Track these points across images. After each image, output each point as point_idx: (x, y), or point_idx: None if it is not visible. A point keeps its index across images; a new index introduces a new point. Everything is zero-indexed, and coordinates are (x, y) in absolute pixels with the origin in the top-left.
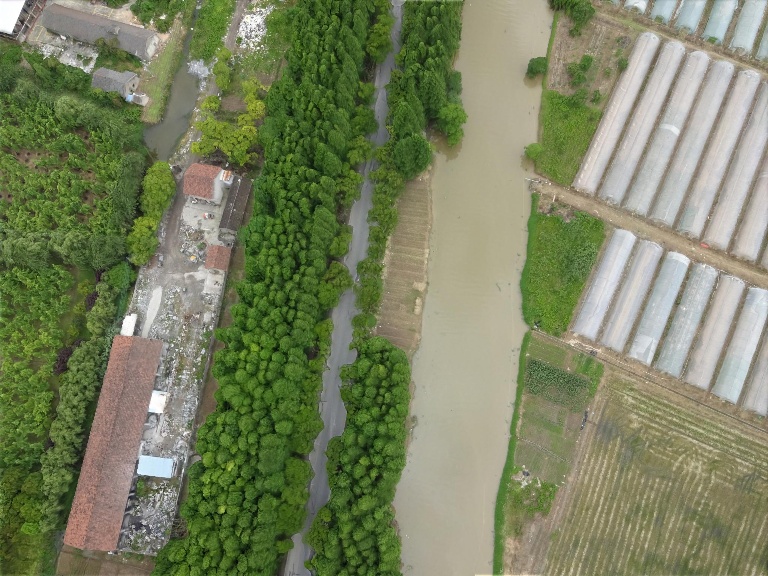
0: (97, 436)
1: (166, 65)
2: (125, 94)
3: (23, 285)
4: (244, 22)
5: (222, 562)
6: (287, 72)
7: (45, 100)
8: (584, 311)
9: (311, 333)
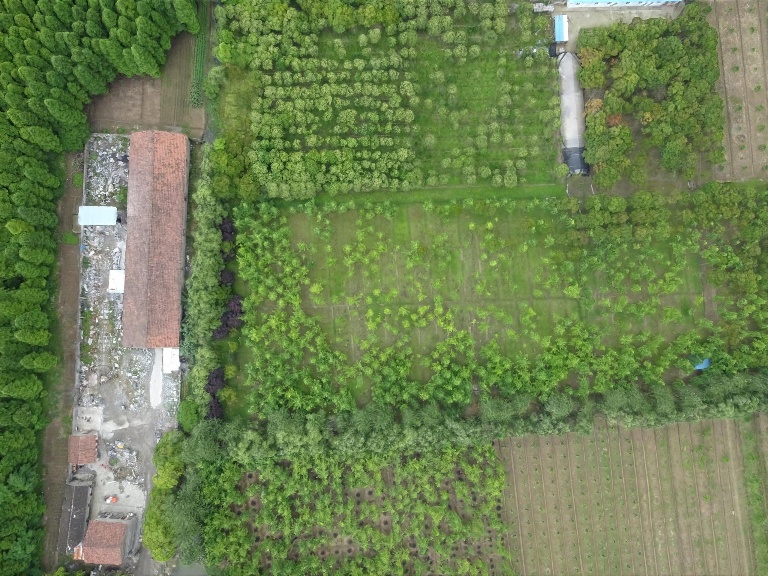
0: (171, 239)
1: None
2: None
3: (306, 391)
4: None
5: None
6: None
7: None
8: None
9: None
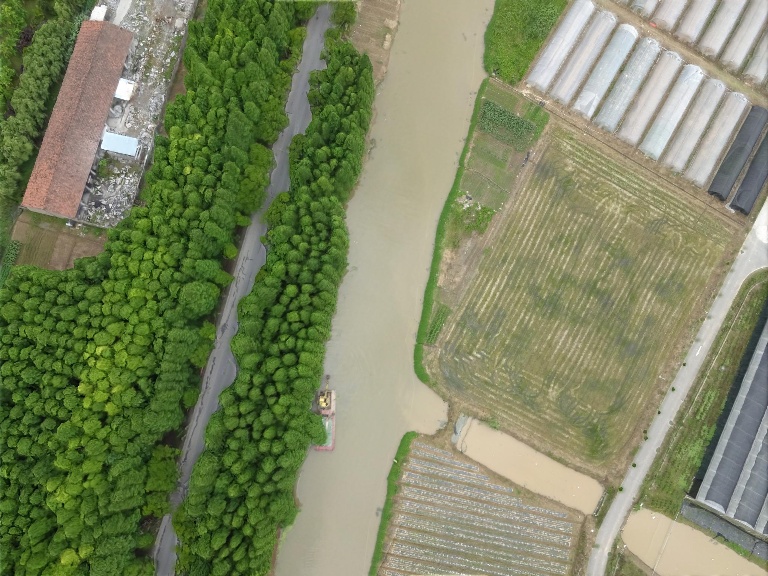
0: (61, 111)
1: None
2: None
3: None
4: None
5: (185, 211)
6: None
7: None
8: (539, 64)
9: (285, 34)
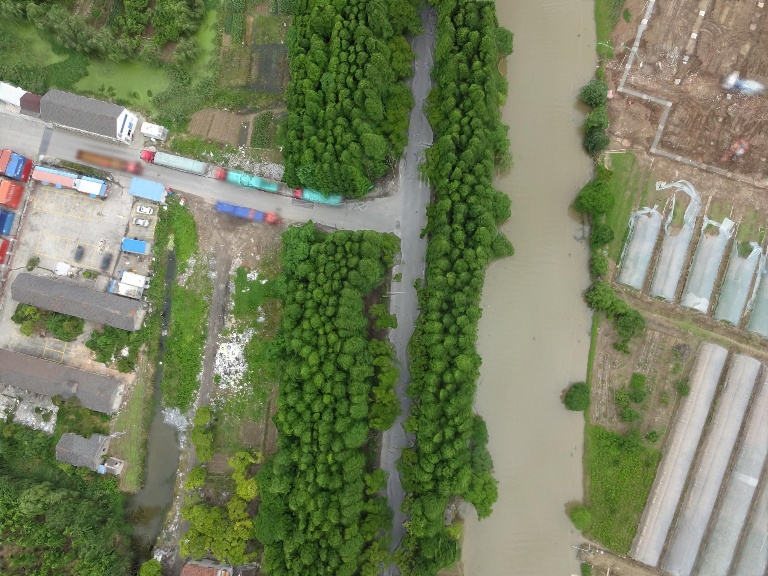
0: None
1: (137, 415)
2: (96, 467)
3: None
4: (220, 354)
5: None
6: (278, 474)
7: (7, 491)
8: None
9: None
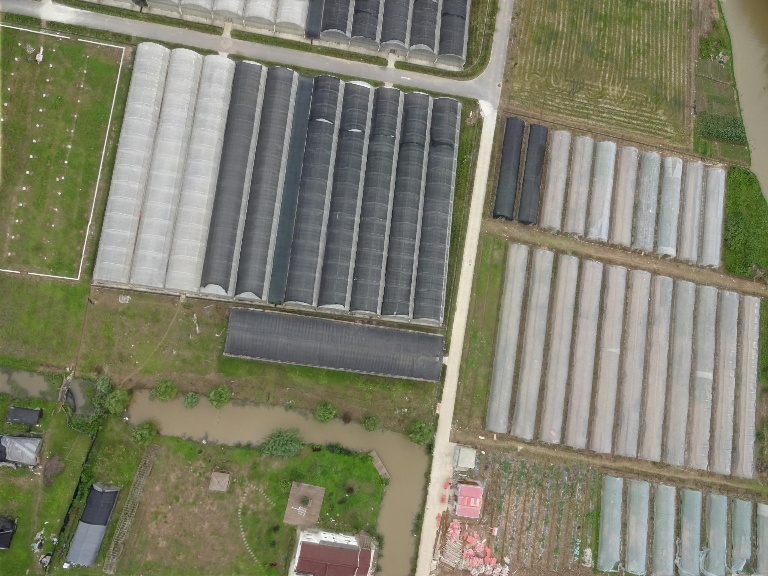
0: None
1: None
2: None
3: None
4: None
5: None
6: None
7: None
8: None
9: None
